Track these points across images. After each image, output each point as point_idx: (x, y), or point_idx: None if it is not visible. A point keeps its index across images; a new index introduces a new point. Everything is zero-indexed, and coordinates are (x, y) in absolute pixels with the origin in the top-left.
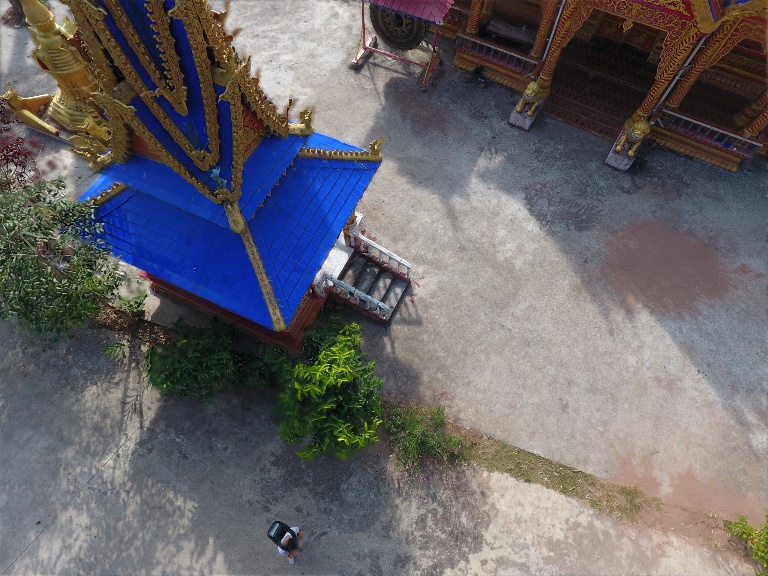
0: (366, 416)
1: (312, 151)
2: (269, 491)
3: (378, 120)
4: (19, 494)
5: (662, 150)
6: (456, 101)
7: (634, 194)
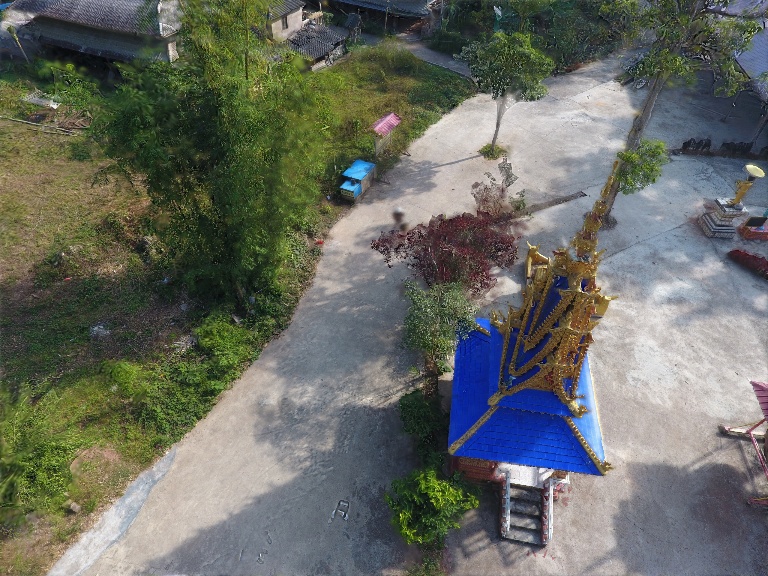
0: (421, 530)
1: (572, 424)
2: (364, 492)
3: (682, 470)
4: (333, 365)
5: None
6: (762, 541)
7: None
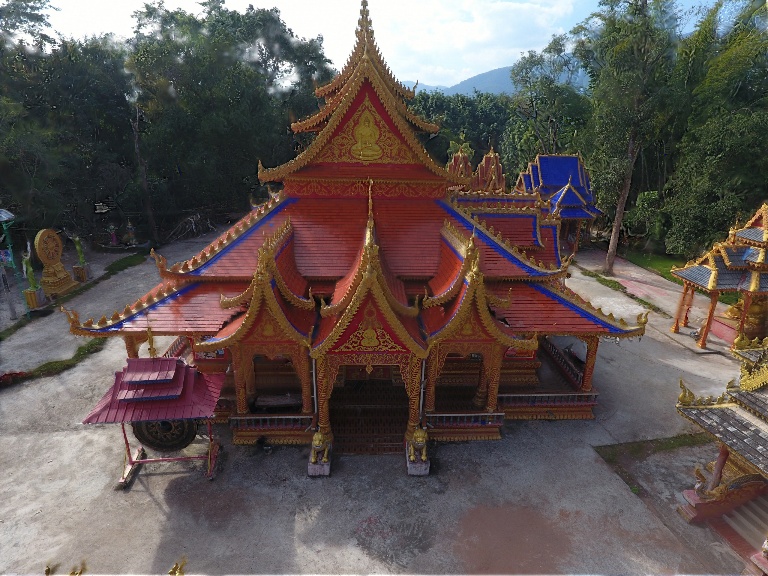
0: None
1: None
2: None
3: (165, 533)
4: None
5: (443, 445)
6: (249, 477)
7: (447, 491)
